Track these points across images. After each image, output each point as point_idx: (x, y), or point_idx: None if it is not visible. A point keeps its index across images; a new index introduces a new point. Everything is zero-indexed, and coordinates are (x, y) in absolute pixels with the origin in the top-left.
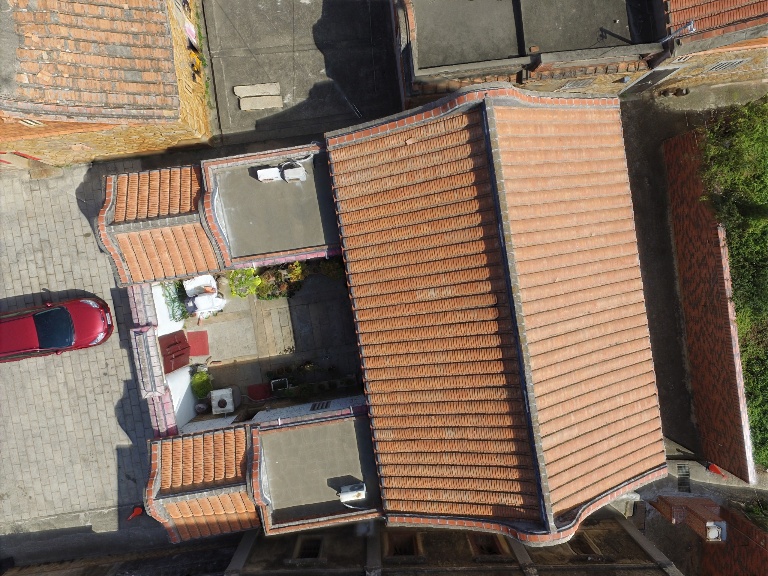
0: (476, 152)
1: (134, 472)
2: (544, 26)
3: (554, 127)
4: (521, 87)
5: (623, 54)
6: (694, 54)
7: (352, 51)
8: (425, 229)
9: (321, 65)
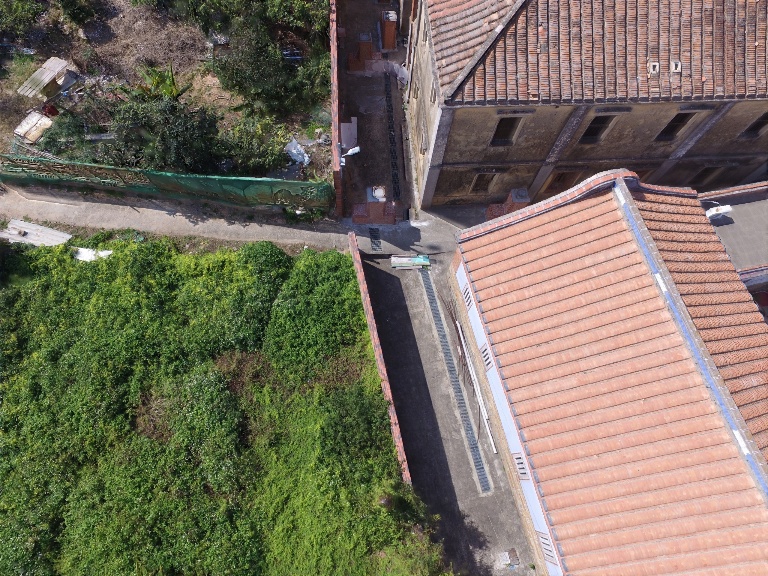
0: None
1: None
2: None
3: None
4: None
5: None
6: None
7: None
8: None
9: None
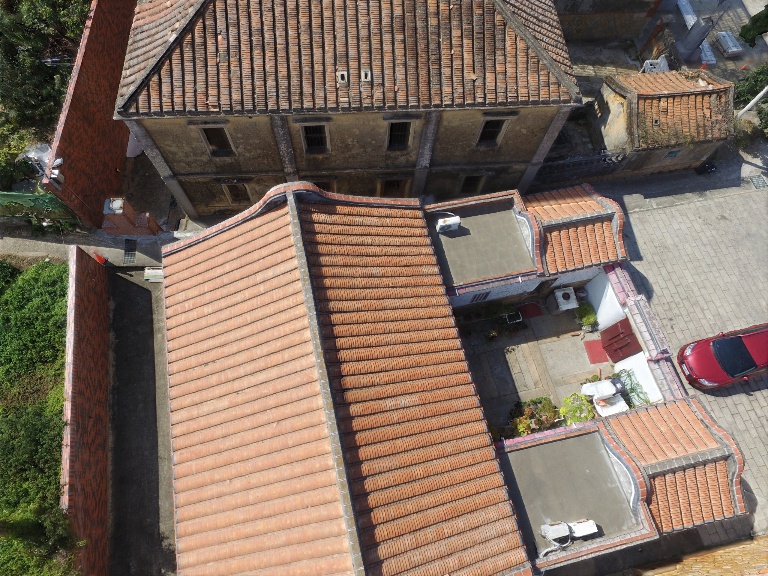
0: (376, 568)
1: None
2: None
3: None
4: None
5: None
6: None
7: None
8: (418, 472)
9: None
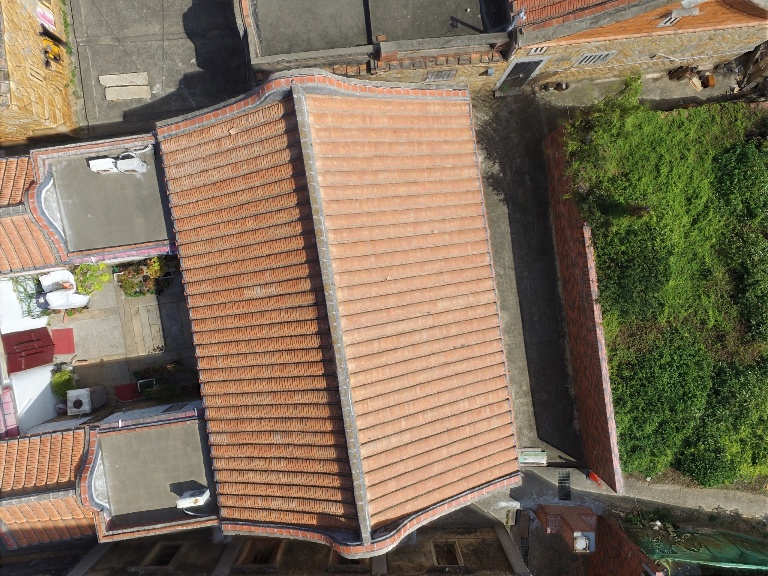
0: (292, 143)
1: None
2: (392, 14)
3: (387, 118)
4: (378, 78)
5: (467, 44)
6: (546, 45)
7: (224, 41)
8: (250, 223)
9: (191, 55)
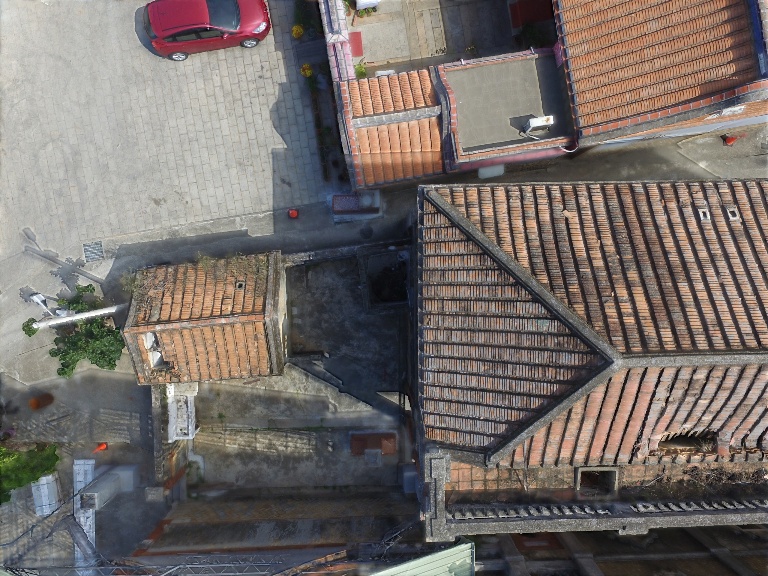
0: None
1: (289, 176)
2: None
3: None
4: None
5: None
6: None
7: None
8: None
9: None
